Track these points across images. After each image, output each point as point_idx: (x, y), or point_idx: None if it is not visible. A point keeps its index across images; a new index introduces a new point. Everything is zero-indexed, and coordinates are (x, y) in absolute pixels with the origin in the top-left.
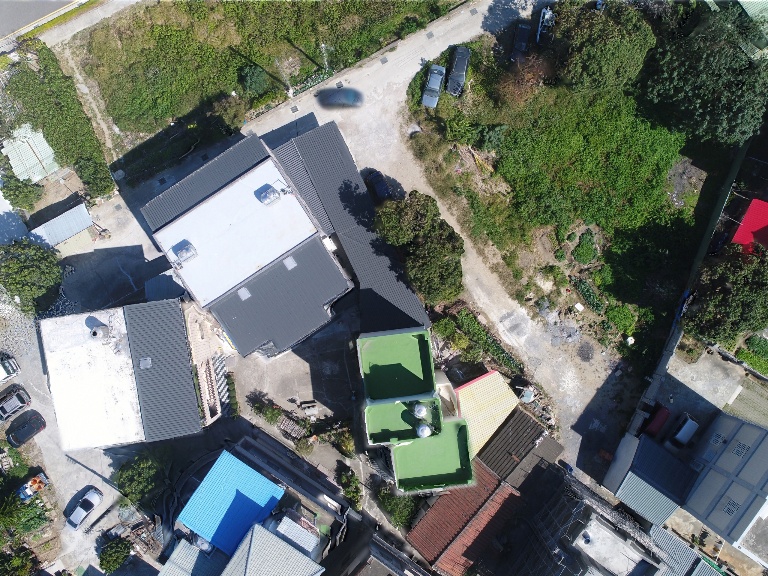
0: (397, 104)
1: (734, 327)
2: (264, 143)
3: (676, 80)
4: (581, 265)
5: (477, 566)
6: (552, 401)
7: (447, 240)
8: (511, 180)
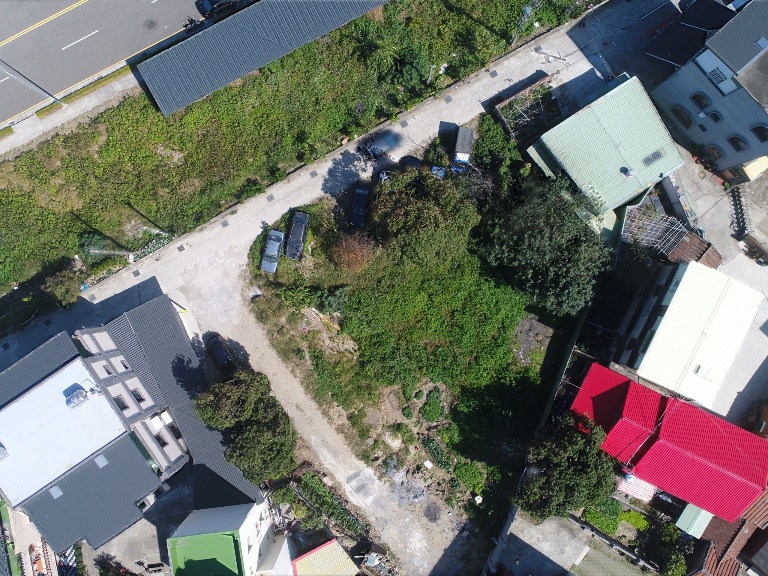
0: (238, 267)
1: (561, 507)
2: (81, 334)
3: (506, 252)
4: (429, 423)
5: None
6: (399, 562)
7: (271, 423)
8: (357, 339)
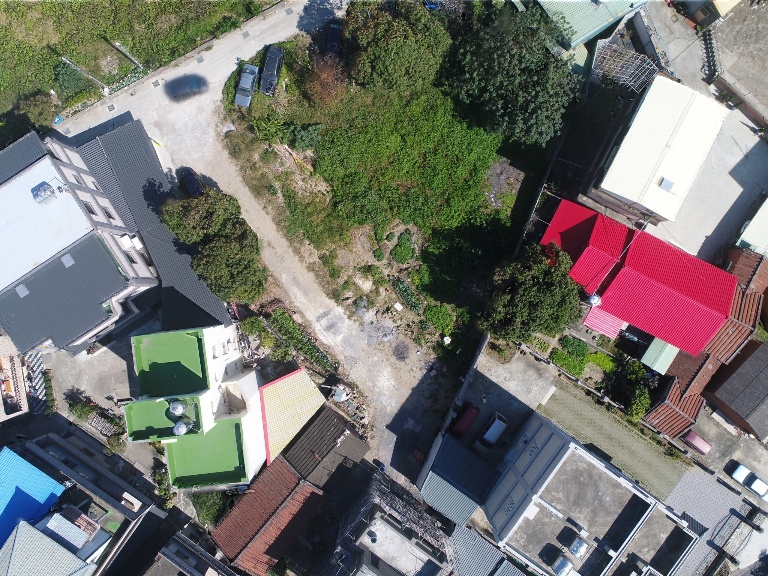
0: (213, 103)
1: (525, 327)
2: (51, 141)
3: (477, 80)
4: (399, 265)
5: (286, 564)
6: (367, 400)
7: (239, 239)
8: (329, 179)
